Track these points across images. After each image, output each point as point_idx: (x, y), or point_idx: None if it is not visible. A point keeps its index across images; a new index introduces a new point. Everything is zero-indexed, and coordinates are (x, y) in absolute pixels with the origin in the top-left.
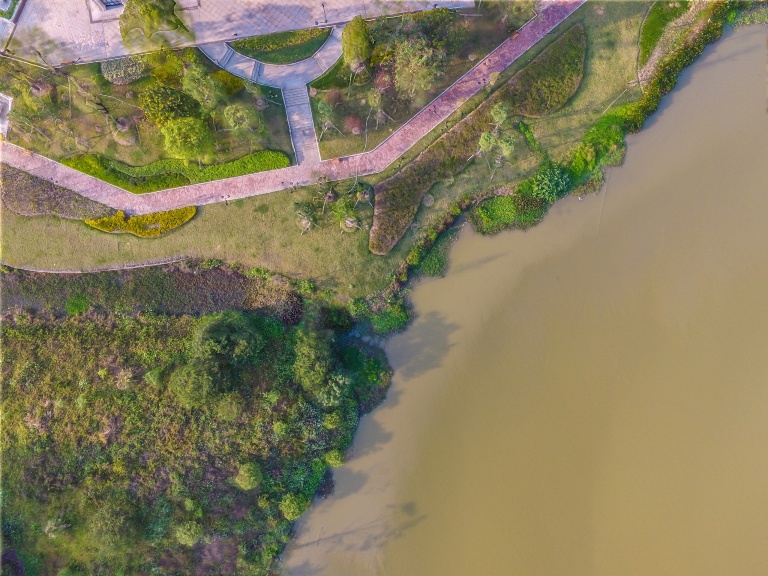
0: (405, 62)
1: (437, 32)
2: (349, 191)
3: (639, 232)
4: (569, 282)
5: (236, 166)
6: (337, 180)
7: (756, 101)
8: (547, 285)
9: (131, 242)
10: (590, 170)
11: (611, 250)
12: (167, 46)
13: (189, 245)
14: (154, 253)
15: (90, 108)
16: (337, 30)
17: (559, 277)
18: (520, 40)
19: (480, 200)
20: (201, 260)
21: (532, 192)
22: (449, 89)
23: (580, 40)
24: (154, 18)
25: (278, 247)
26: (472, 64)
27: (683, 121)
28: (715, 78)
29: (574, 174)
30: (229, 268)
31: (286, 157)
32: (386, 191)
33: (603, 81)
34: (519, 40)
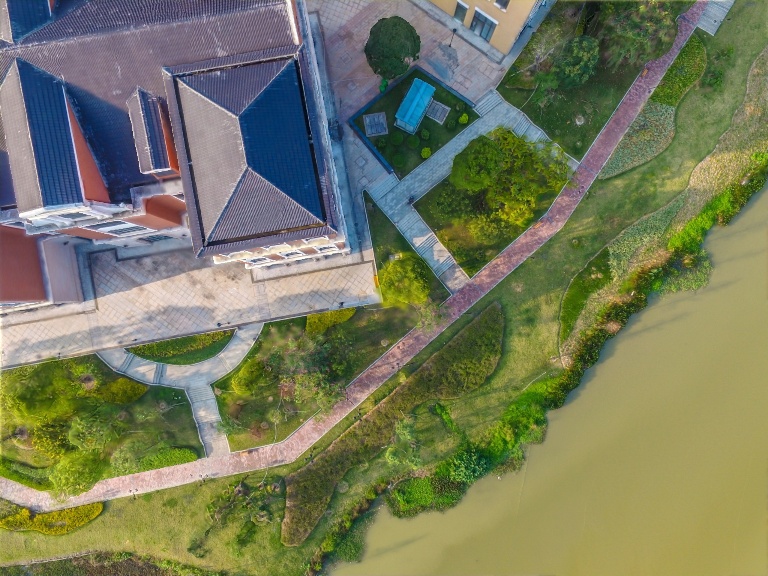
0: None
1: (336, 357)
2: (259, 483)
3: (560, 512)
4: (488, 564)
5: (142, 464)
6: (247, 471)
7: (682, 371)
8: (466, 568)
9: (38, 539)
10: (510, 448)
11: (532, 529)
12: (65, 353)
13: (97, 540)
14: (62, 549)
15: None
16: (240, 331)
17: (478, 559)
18: None
19: (396, 482)
20: (110, 554)
21: (449, 475)
22: (362, 375)
23: (497, 320)
24: (23, 411)
25: (188, 542)
26: (385, 349)
27: (606, 395)
28: (640, 348)
29: (493, 454)
30: (139, 560)
31: (193, 453)
32: (297, 484)
33: (523, 358)
34: None
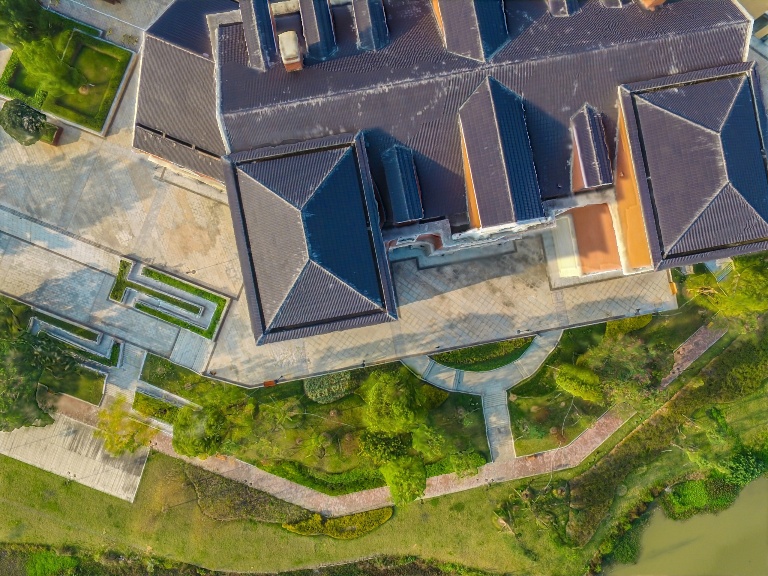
0: (623, 391)
1: (657, 364)
2: (545, 487)
3: None
4: (760, 564)
5: (433, 469)
6: (532, 476)
7: None
8: (739, 569)
9: (327, 543)
10: None
11: None
12: (369, 361)
13: (385, 544)
14: (350, 553)
15: (293, 425)
16: (539, 338)
17: (751, 560)
18: (714, 327)
19: (671, 485)
20: (396, 557)
21: (724, 477)
22: None
23: None
24: (411, 419)
25: (475, 545)
26: None
27: None
28: None
29: (766, 457)
30: (424, 563)
31: (483, 458)
32: (583, 487)
33: None
34: (713, 327)
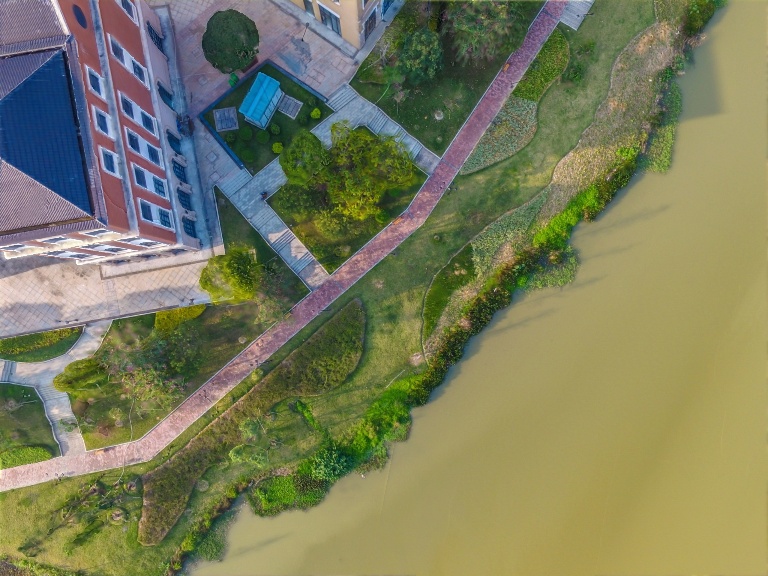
0: None
1: None
2: (116, 482)
3: (424, 510)
4: (352, 562)
5: None
6: (104, 470)
7: (548, 368)
8: (329, 567)
9: None
10: (373, 446)
11: (396, 528)
12: None
13: None
14: None
15: None
16: (89, 329)
17: (341, 558)
18: (294, 318)
19: (258, 481)
20: None
21: (311, 473)
22: (220, 372)
23: (357, 317)
24: None
25: (43, 541)
26: (243, 346)
27: (471, 392)
28: (505, 345)
29: (356, 452)
30: None
31: (47, 451)
32: (154, 482)
33: (385, 355)
34: (293, 318)
